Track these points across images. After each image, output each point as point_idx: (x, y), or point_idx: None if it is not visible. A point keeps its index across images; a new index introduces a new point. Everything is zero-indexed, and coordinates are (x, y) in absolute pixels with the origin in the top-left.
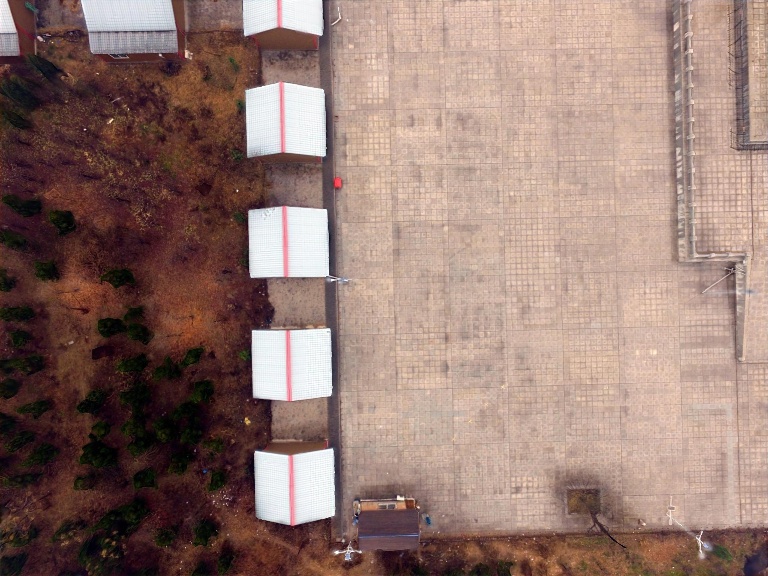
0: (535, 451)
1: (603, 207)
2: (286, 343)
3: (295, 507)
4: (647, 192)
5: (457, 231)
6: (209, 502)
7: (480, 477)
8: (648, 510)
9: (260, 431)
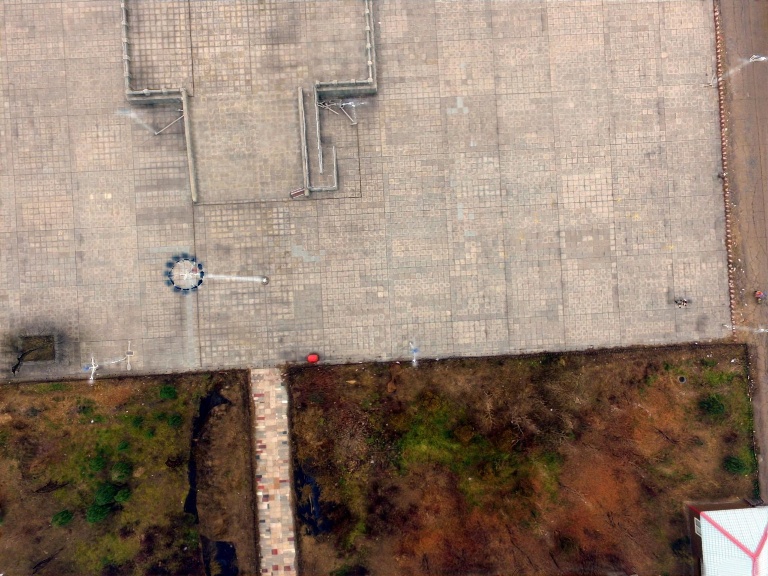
0: None
1: (52, 50)
2: None
3: None
4: (96, 34)
5: None
6: None
7: None
8: (106, 356)
9: None
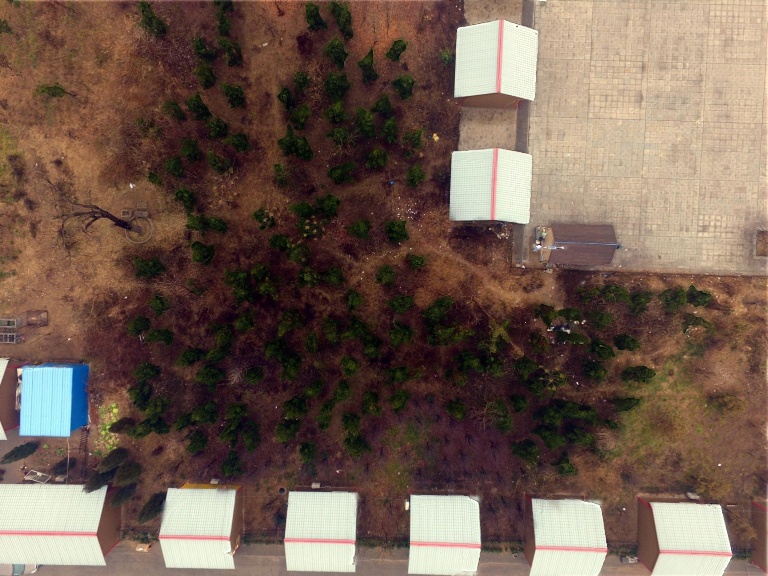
0: (726, 190)
1: None
2: (499, 33)
3: (497, 202)
4: None
5: None
6: (394, 214)
7: (667, 213)
8: None
9: (448, 149)
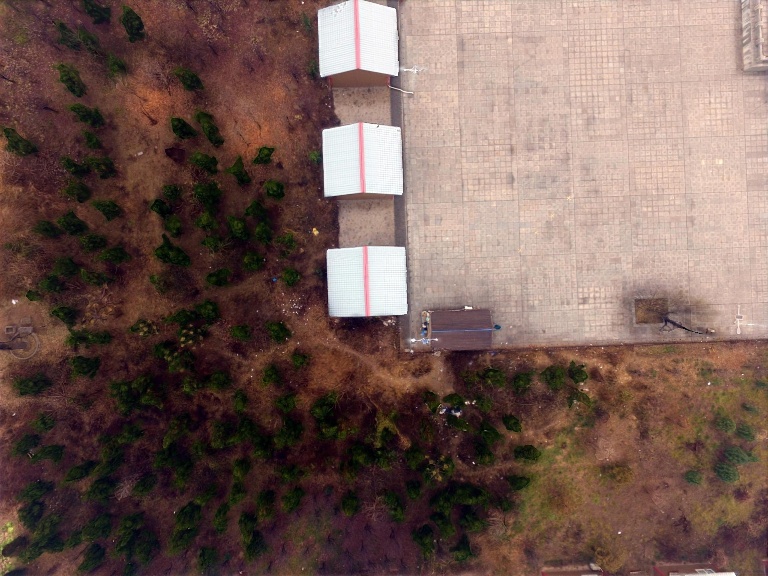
0: (602, 262)
1: (667, 17)
2: (359, 135)
3: (370, 298)
4: (711, 2)
5: (521, 43)
6: (279, 310)
7: (547, 288)
8: (716, 319)
9: (328, 242)
